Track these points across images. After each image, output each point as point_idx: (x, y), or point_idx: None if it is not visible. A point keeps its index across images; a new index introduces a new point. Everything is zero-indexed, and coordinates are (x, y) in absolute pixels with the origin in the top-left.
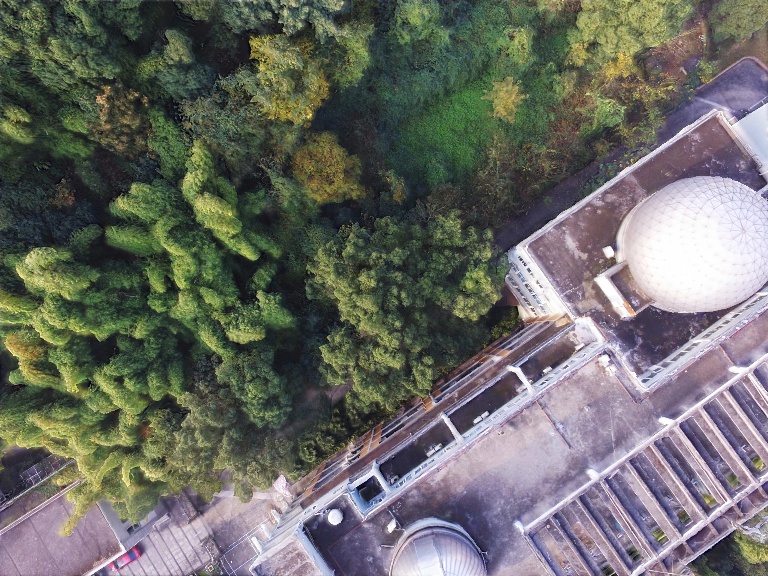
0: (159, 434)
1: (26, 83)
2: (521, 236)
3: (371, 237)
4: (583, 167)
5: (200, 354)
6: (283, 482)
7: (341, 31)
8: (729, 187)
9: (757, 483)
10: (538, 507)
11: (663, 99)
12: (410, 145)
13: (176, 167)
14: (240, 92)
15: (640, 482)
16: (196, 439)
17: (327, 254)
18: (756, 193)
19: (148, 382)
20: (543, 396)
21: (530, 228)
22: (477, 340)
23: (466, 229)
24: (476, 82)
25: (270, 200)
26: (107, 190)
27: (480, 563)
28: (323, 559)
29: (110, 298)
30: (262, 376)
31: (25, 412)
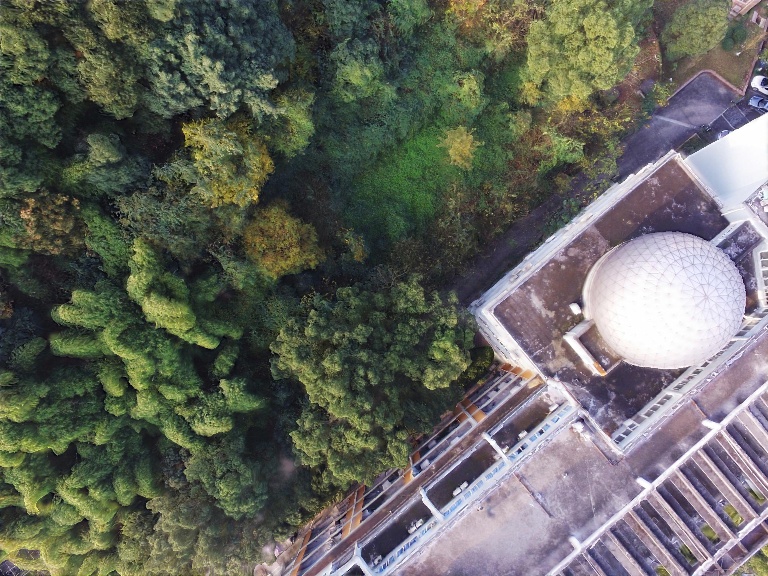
0: None
1: None
2: (491, 274)
3: (333, 310)
4: (548, 199)
5: (167, 448)
6: None
7: (279, 109)
8: (689, 249)
9: (736, 539)
10: None
11: (622, 129)
12: (368, 198)
13: (119, 265)
14: (179, 181)
15: (621, 549)
16: (170, 544)
17: (289, 334)
18: (717, 251)
19: (114, 489)
20: (520, 467)
21: (499, 265)
22: (451, 402)
23: (430, 294)
24: (430, 128)
25: (224, 285)
26: (48, 294)
27: None
28: None
29: (63, 411)
30: (233, 470)
31: None
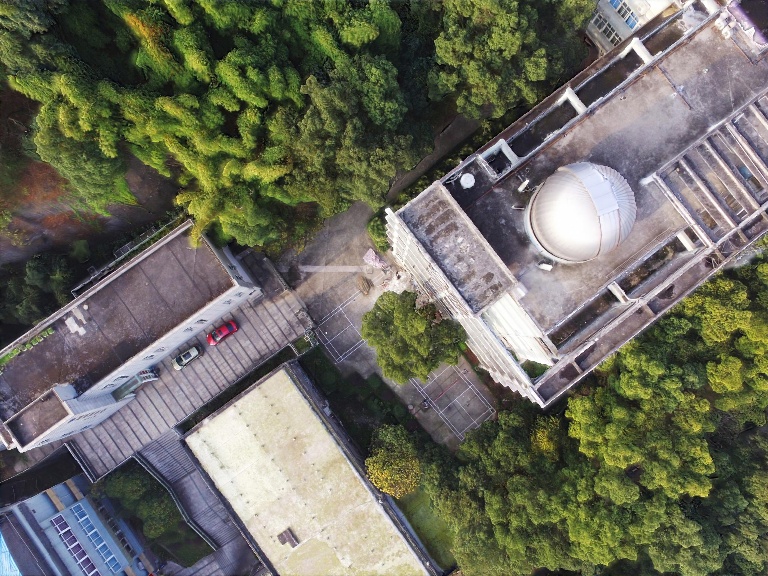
0: None
1: None
2: None
3: None
4: None
5: (311, 64)
6: (372, 255)
7: None
8: None
9: None
10: (662, 165)
11: None
12: None
13: None
14: None
15: (765, 122)
16: (323, 122)
17: None
18: None
19: (269, 75)
20: (662, 61)
21: None
22: (578, 55)
23: None
24: None
25: None
26: None
27: None
28: None
29: None
30: (381, 68)
31: (154, 97)
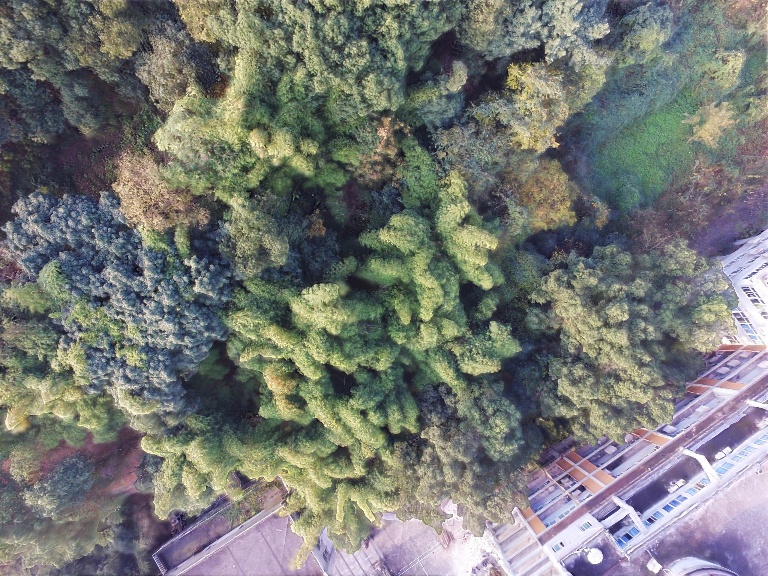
0: (389, 466)
1: (317, 115)
2: None
3: (597, 266)
4: None
5: (426, 384)
6: (454, 506)
7: (600, 60)
8: None
9: None
10: None
11: None
12: (602, 168)
13: (422, 196)
14: (492, 121)
15: None
16: (444, 474)
17: (557, 284)
18: None
19: (389, 415)
20: None
21: None
22: (695, 371)
23: None
24: (672, 105)
25: (504, 229)
26: (348, 219)
27: None
28: None
29: (361, 331)
30: (502, 410)
31: (273, 446)
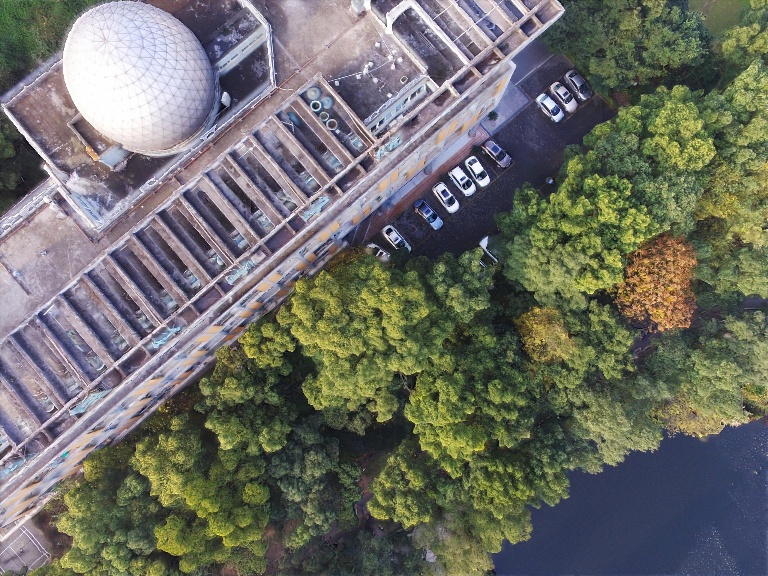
0: None
1: None
2: None
3: None
4: None
5: None
6: None
7: None
8: (111, 4)
9: (187, 301)
10: None
11: None
12: None
13: None
14: None
15: (71, 314)
16: None
17: None
18: (149, 9)
19: None
20: None
21: None
22: None
23: None
24: None
25: None
26: None
27: None
28: None
29: None
30: None
31: None
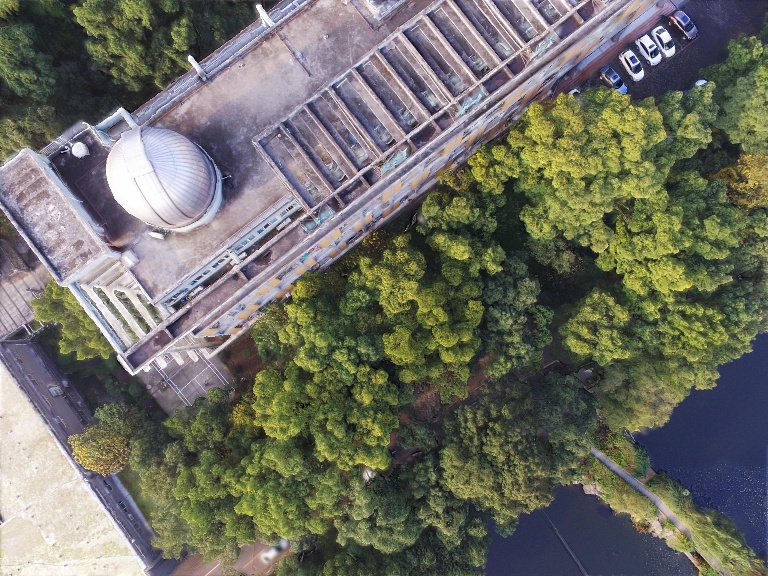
0: None
1: None
2: None
3: None
4: None
5: None
6: None
7: None
8: None
9: (478, 81)
10: None
11: None
12: None
13: None
14: None
15: (365, 86)
16: None
17: None
18: None
19: None
20: (282, 28)
21: None
22: None
23: None
24: None
25: None
26: None
27: (194, 147)
28: (71, 193)
29: None
30: (15, 38)
31: None
